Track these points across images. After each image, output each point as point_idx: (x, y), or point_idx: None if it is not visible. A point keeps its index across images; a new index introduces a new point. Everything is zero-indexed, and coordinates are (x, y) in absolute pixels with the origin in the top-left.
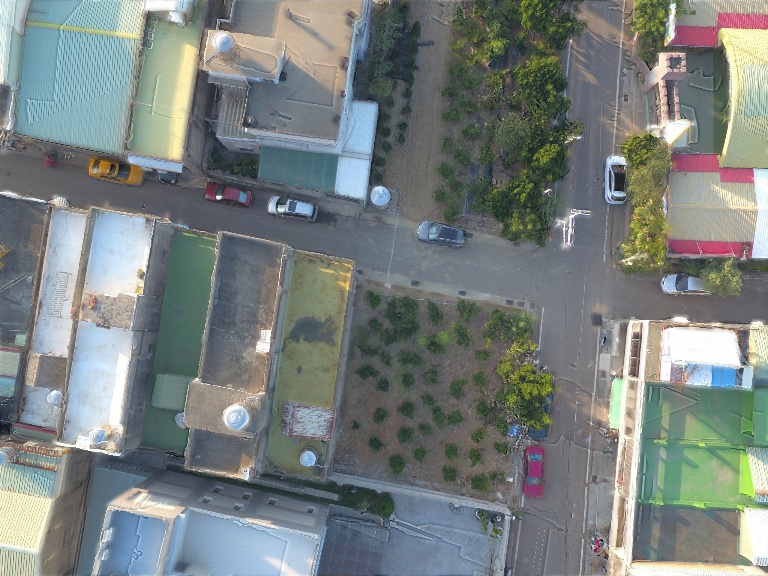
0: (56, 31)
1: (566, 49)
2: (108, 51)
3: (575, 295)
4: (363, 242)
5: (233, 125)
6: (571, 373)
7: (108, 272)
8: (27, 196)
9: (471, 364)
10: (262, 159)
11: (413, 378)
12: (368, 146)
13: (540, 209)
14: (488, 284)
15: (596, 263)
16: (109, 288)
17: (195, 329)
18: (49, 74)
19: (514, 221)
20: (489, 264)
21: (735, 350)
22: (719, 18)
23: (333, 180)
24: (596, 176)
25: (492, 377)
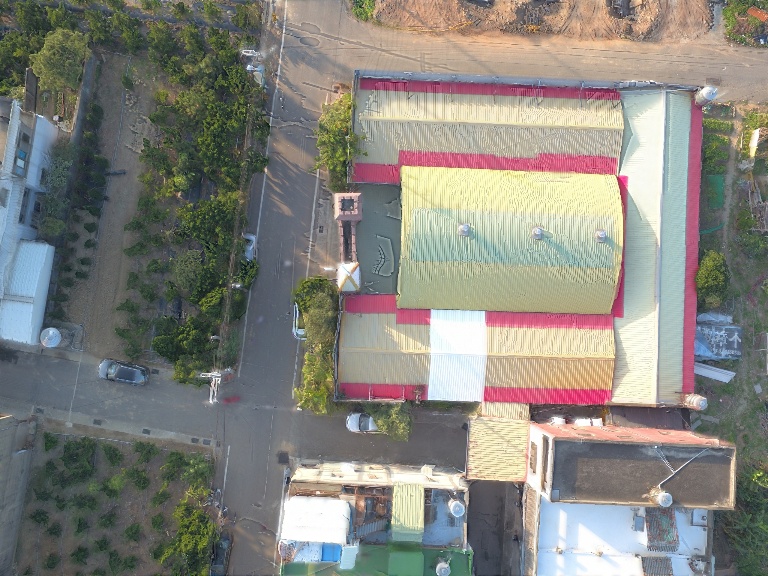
0: None
1: (260, 179)
2: None
3: (262, 433)
4: (45, 379)
5: None
6: (255, 513)
7: None
8: None
9: None
10: None
11: (85, 523)
12: (33, 289)
13: (210, 353)
14: (173, 422)
15: (284, 400)
16: None
17: None
18: None
19: (176, 369)
20: (175, 401)
21: (344, 527)
22: (399, 156)
23: None
24: (288, 310)
25: (175, 518)
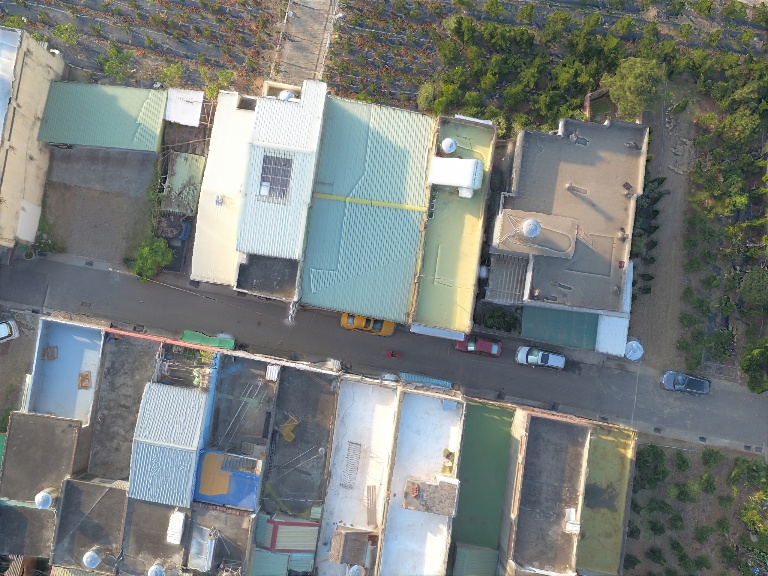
0: (342, 203)
1: None
2: (393, 223)
3: None
4: (607, 390)
5: (511, 293)
6: None
7: (415, 452)
8: (278, 346)
9: (713, 509)
10: (525, 318)
11: (664, 527)
12: (626, 304)
13: None
14: (727, 430)
15: None
16: (416, 468)
17: (482, 497)
18: (334, 244)
19: None
20: (728, 410)
21: None
22: None
23: (594, 338)
24: None
25: (733, 521)
